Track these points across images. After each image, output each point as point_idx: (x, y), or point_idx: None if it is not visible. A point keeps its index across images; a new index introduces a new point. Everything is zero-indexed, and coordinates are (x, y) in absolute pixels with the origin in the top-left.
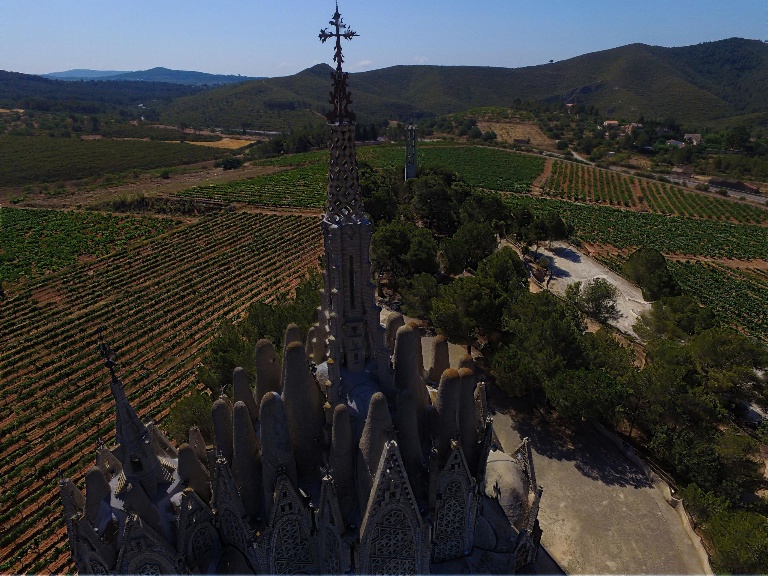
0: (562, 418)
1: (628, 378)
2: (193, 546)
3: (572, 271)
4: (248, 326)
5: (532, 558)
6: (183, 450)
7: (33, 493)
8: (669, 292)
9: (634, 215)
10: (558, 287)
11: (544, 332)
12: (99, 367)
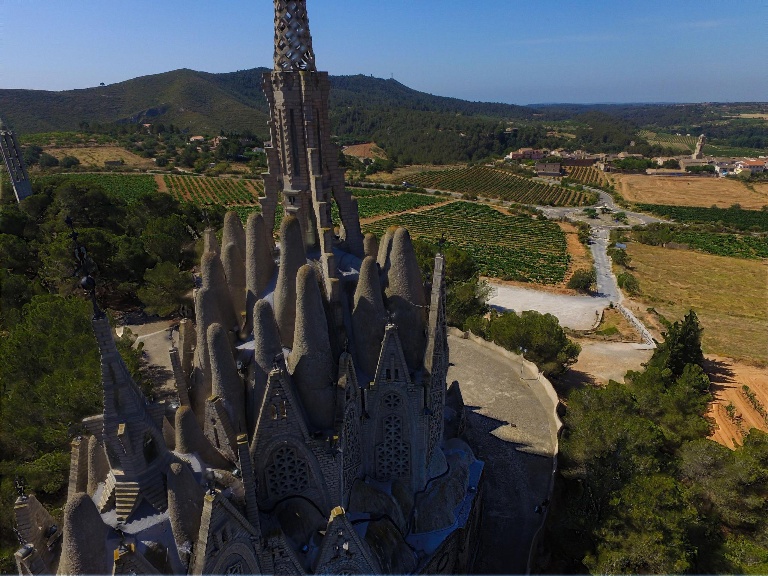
0: None
1: None
2: None
3: None
4: None
5: None
6: (188, 412)
7: None
8: None
9: None
10: None
11: None
12: None
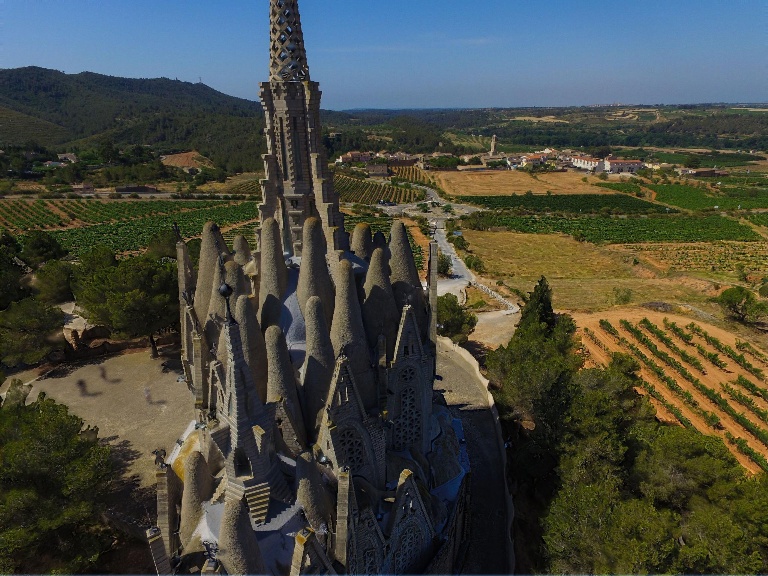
0: None
1: None
2: None
3: None
4: None
5: None
6: None
7: None
8: None
9: (81, 230)
10: None
11: None
12: None
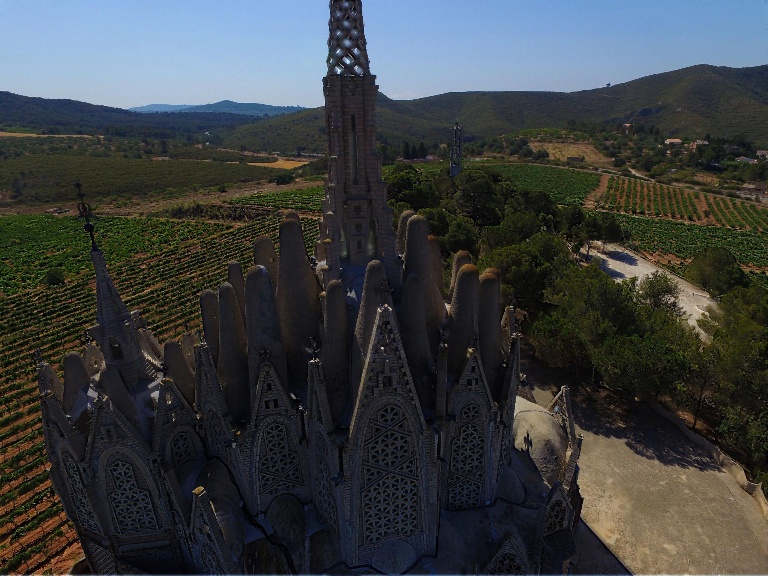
0: (612, 397)
1: (691, 353)
2: (172, 450)
3: (628, 273)
4: None
5: (569, 523)
6: (169, 344)
7: None
8: None
9: (699, 228)
10: None
11: None
12: None
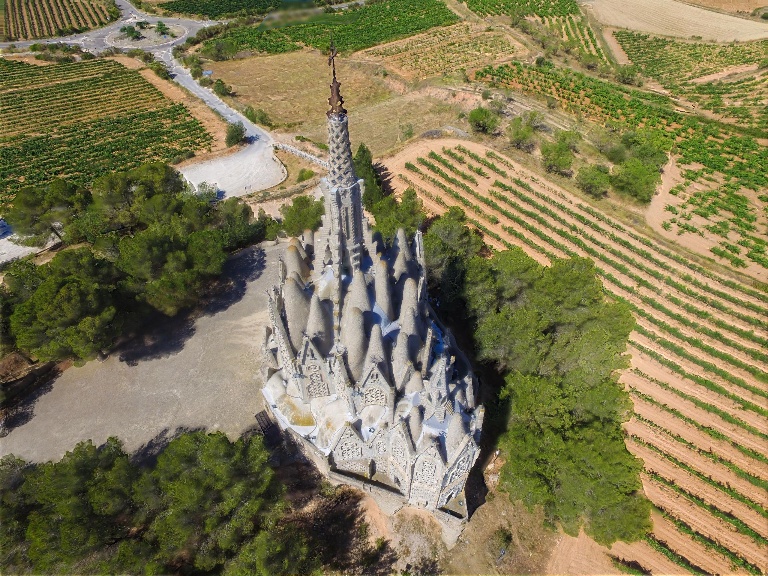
0: None
1: None
2: None
3: None
4: None
5: None
6: None
7: None
8: None
9: None
10: None
11: None
12: None
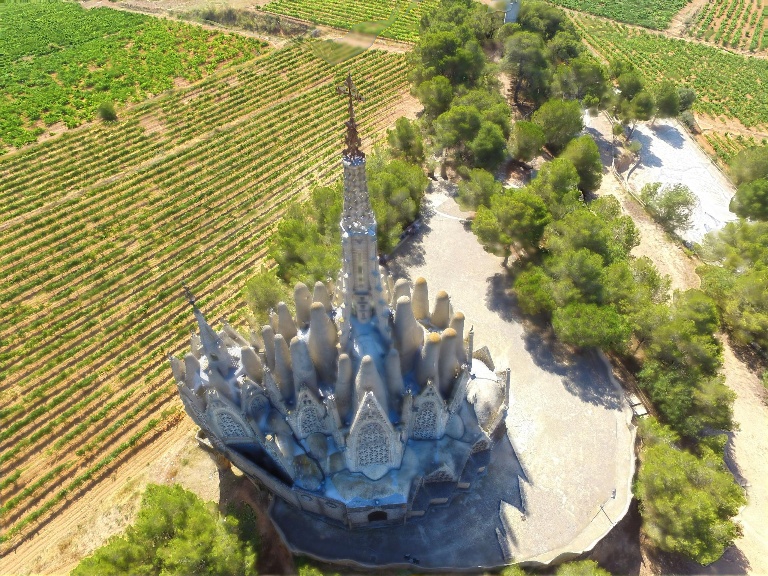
0: None
1: (640, 316)
2: (251, 407)
3: (666, 159)
4: (313, 205)
5: (490, 447)
6: (244, 351)
7: (157, 310)
8: (759, 208)
9: None
10: (641, 178)
11: (573, 261)
12: (197, 209)
